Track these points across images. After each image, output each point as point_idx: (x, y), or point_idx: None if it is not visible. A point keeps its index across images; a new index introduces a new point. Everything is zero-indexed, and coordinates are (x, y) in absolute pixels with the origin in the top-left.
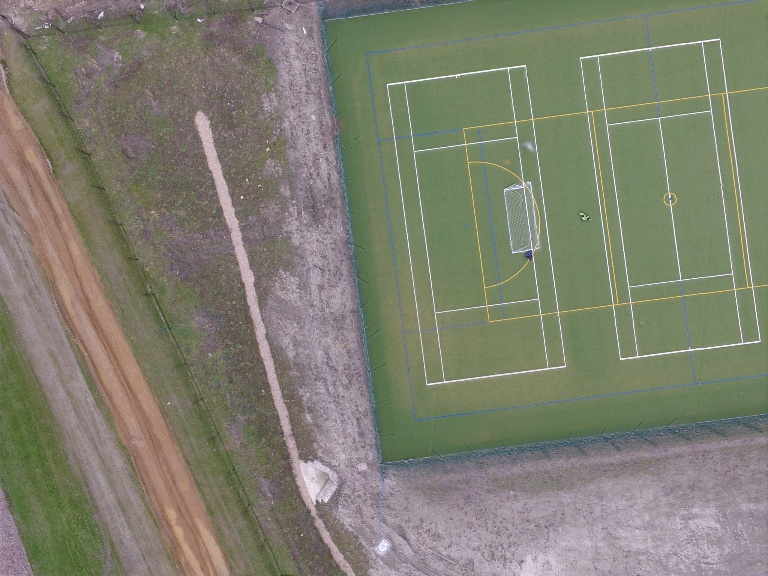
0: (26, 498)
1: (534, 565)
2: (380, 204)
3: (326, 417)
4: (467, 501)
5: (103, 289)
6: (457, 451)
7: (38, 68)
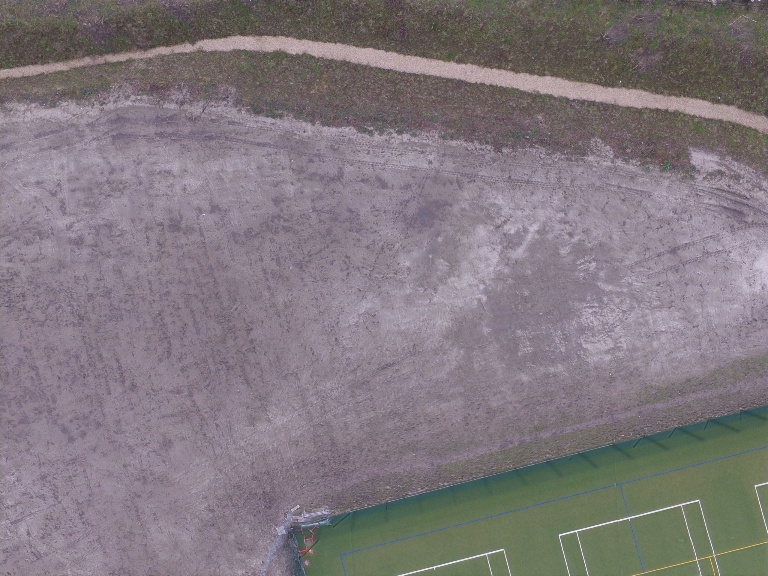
0: None
1: (764, 281)
2: None
3: None
4: None
5: None
6: None
7: None
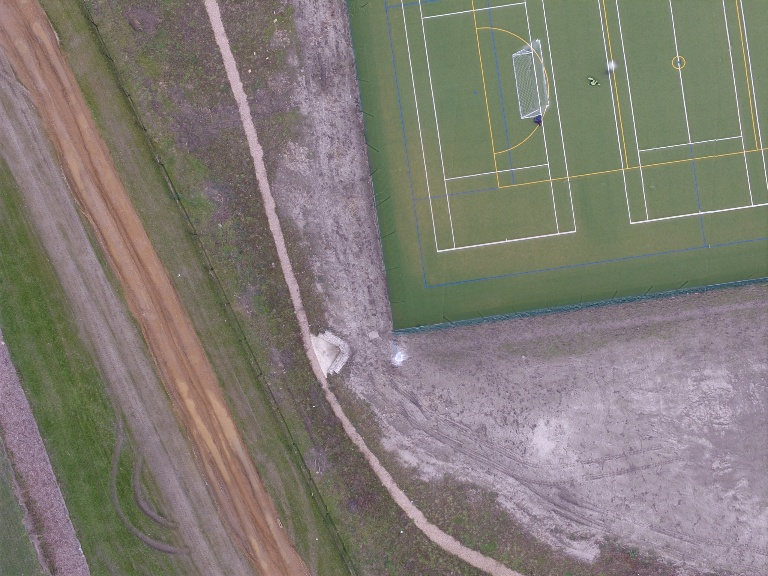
0: (37, 372)
1: (547, 429)
2: (388, 71)
3: (337, 286)
4: (479, 367)
5: (112, 161)
6: (468, 317)
7: None
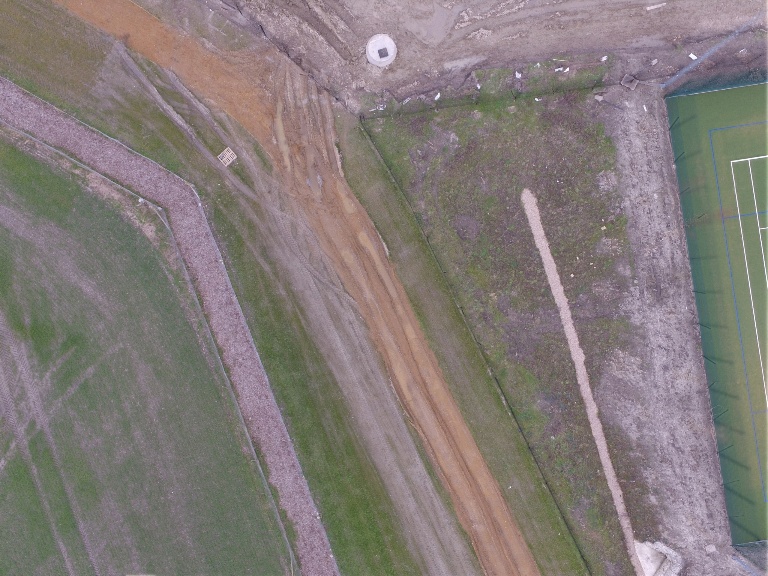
0: None
1: None
2: (726, 283)
3: (673, 499)
4: None
5: (441, 373)
6: None
7: (372, 150)
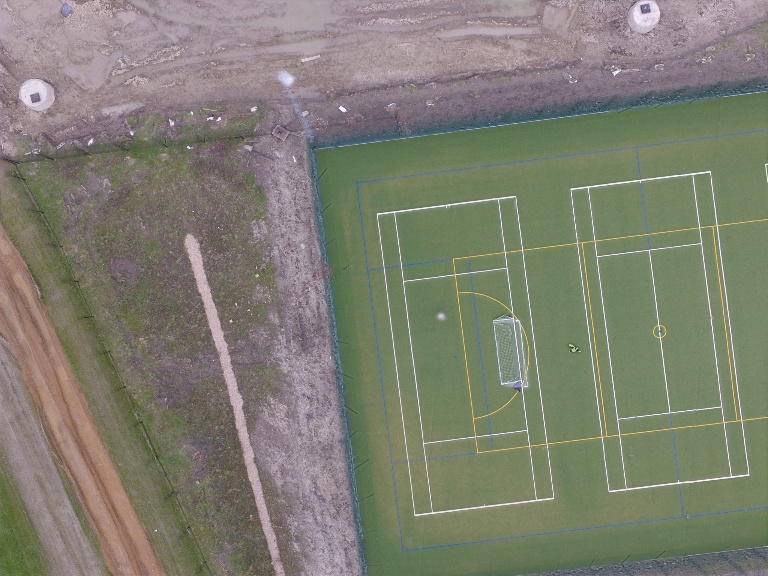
0: None
1: None
2: (369, 334)
3: (313, 547)
4: None
5: (91, 415)
6: None
7: (27, 194)
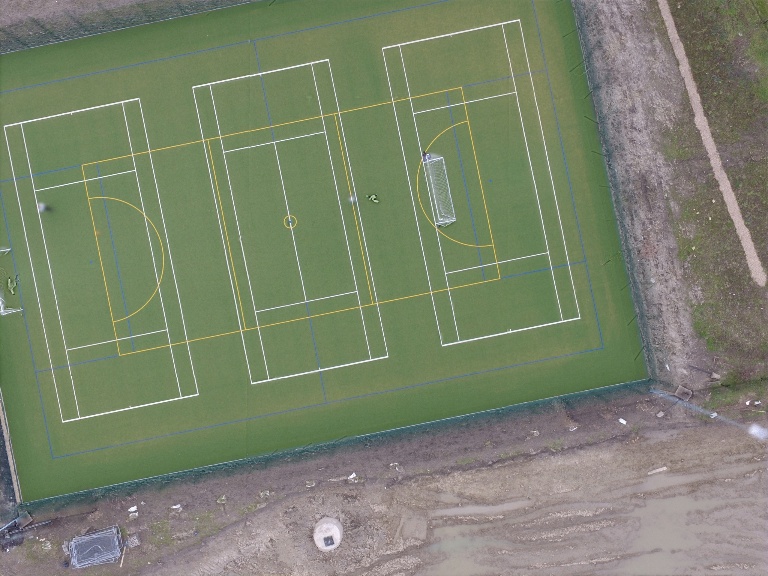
0: None
1: None
2: (579, 198)
3: None
4: None
5: None
6: None
7: None
